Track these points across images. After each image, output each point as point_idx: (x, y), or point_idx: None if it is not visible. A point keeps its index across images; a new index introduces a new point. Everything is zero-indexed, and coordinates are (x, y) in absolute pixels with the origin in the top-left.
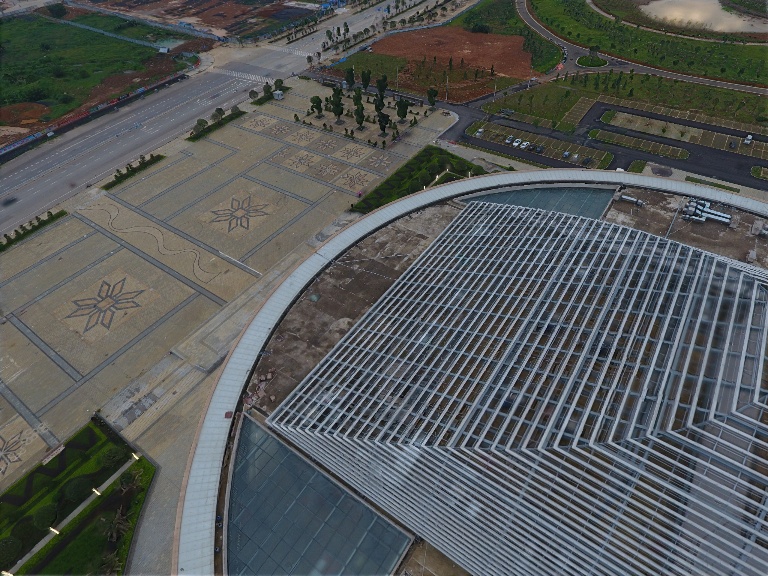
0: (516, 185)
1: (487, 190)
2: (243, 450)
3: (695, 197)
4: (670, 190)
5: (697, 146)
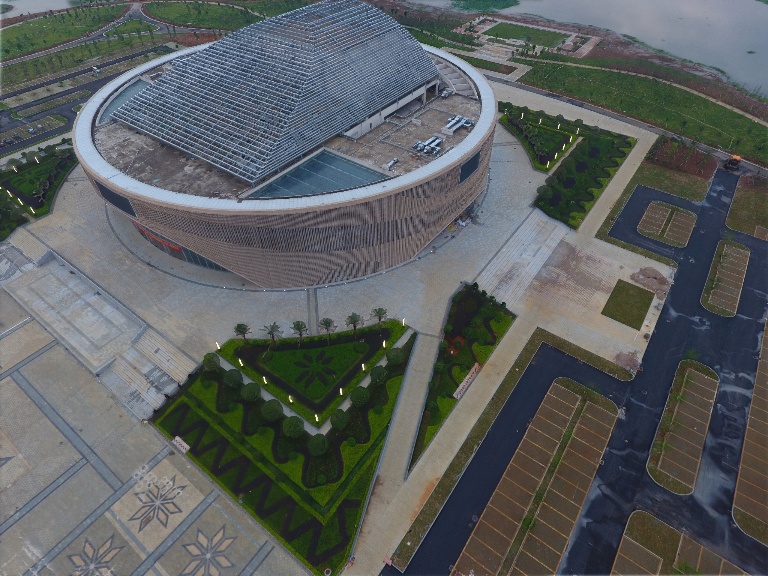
0: (103, 104)
1: None
2: None
3: None
4: (157, 65)
5: (82, 86)
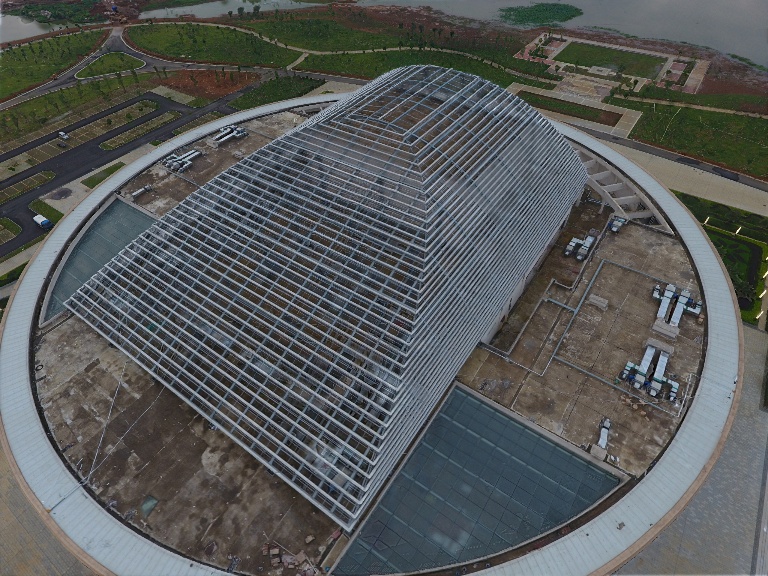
0: (55, 265)
1: (46, 291)
2: (376, 567)
3: (159, 160)
4: (142, 168)
5: (44, 163)
